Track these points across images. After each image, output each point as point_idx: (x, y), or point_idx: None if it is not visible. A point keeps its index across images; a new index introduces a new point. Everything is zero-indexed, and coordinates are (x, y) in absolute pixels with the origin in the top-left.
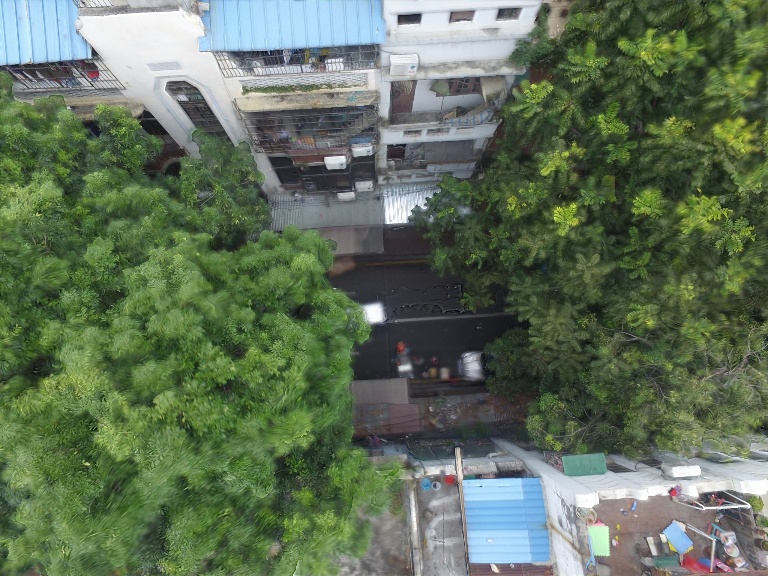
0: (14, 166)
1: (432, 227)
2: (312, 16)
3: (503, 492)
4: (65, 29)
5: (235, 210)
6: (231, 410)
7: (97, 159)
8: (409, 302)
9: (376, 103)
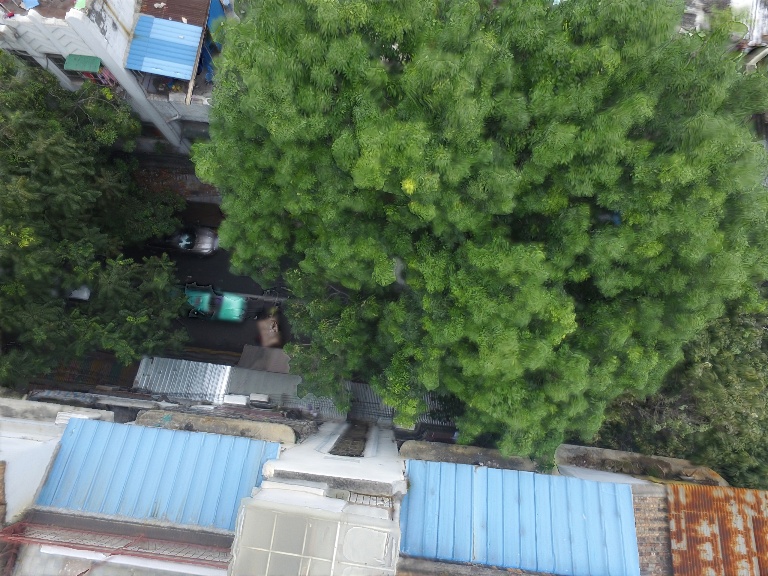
0: (456, 293)
1: (164, 320)
2: (140, 465)
3: (159, 65)
4: (431, 502)
5: (297, 284)
6: (261, 26)
7: (408, 335)
8: (242, 302)
9: (143, 411)
